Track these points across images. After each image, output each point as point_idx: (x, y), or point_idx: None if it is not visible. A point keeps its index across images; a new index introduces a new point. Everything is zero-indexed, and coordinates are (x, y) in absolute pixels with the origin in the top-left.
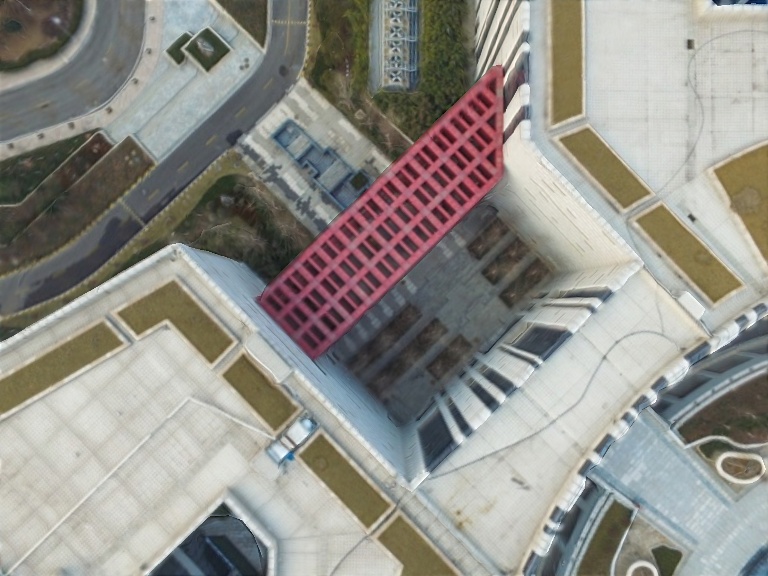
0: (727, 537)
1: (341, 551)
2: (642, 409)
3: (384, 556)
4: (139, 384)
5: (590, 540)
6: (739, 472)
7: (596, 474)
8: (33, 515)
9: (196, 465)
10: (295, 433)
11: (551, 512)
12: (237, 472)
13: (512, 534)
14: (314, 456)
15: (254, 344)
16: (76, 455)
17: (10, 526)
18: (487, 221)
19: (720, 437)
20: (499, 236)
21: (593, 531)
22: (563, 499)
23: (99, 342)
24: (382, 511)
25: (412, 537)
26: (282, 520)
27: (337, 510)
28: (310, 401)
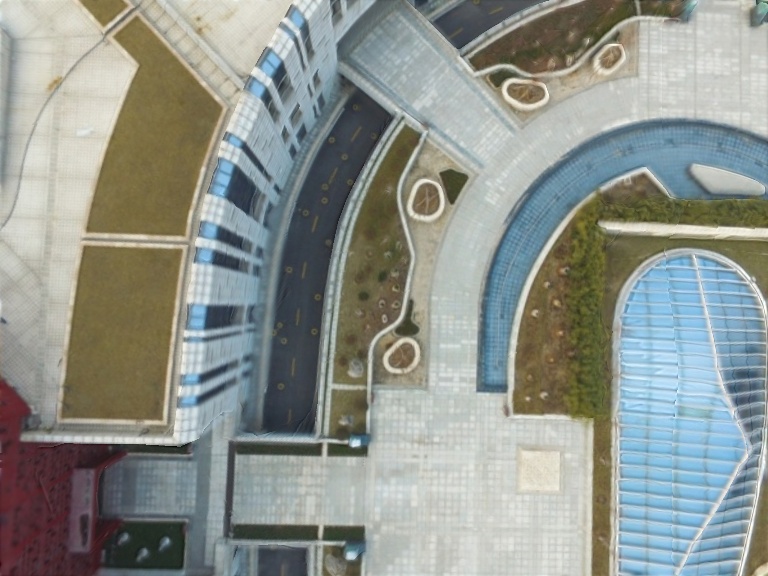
0: (512, 162)
1: (77, 53)
2: None
3: (120, 56)
4: None
5: (380, 162)
6: (522, 95)
7: (388, 98)
8: None
9: None
10: None
11: (286, 12)
12: None
13: (251, 41)
14: None
15: None
16: None
17: None
18: None
19: (508, 66)
20: None
21: (384, 154)
22: None
23: None
24: (119, 10)
25: (149, 37)
26: (18, 21)
27: (75, 13)
28: None
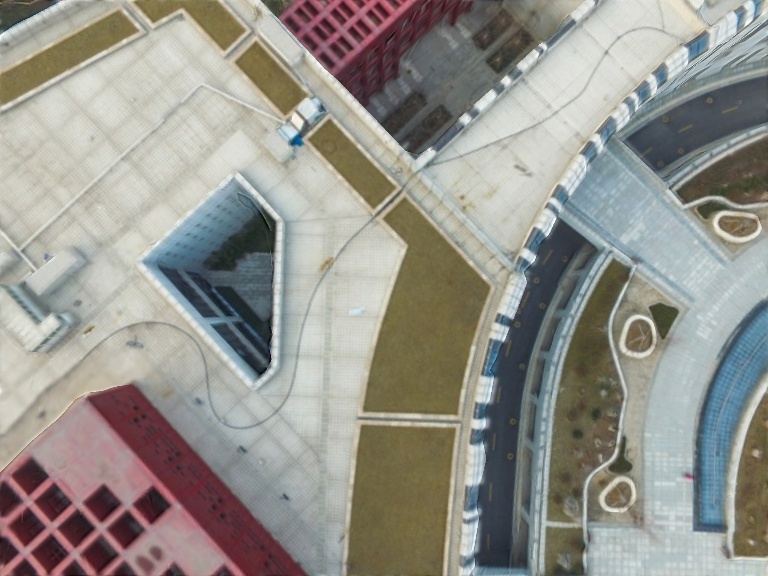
0: (723, 295)
1: (347, 233)
2: (642, 101)
3: (389, 237)
4: (154, 72)
5: (589, 297)
6: (735, 228)
7: (596, 232)
8: (47, 195)
9: (207, 150)
10: (305, 108)
11: (552, 191)
12: (247, 157)
13: (514, 218)
14: (323, 140)
15: (267, 25)
16: (91, 138)
17: (25, 205)
18: (492, 13)
19: (717, 197)
20: (504, 27)
21: (592, 288)
22: (564, 177)
23: (116, 28)
24: (388, 192)
25: (417, 218)
26: (290, 204)
27: (344, 194)
28: (320, 90)
